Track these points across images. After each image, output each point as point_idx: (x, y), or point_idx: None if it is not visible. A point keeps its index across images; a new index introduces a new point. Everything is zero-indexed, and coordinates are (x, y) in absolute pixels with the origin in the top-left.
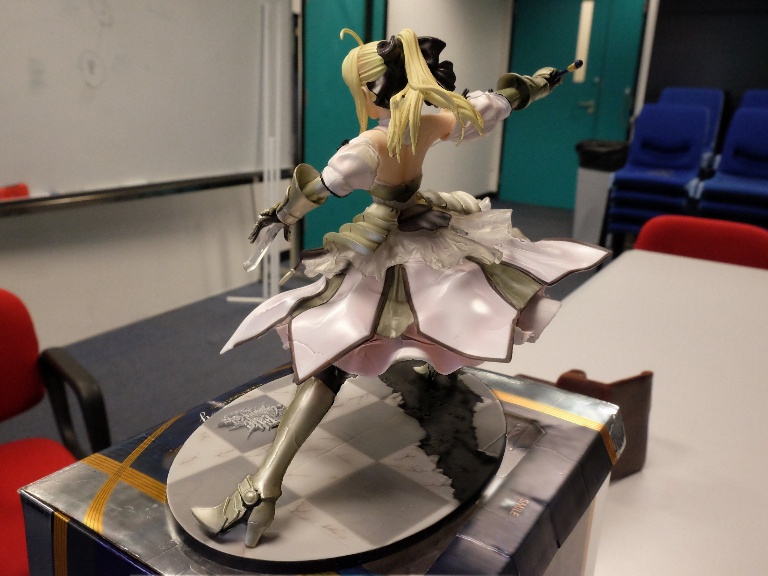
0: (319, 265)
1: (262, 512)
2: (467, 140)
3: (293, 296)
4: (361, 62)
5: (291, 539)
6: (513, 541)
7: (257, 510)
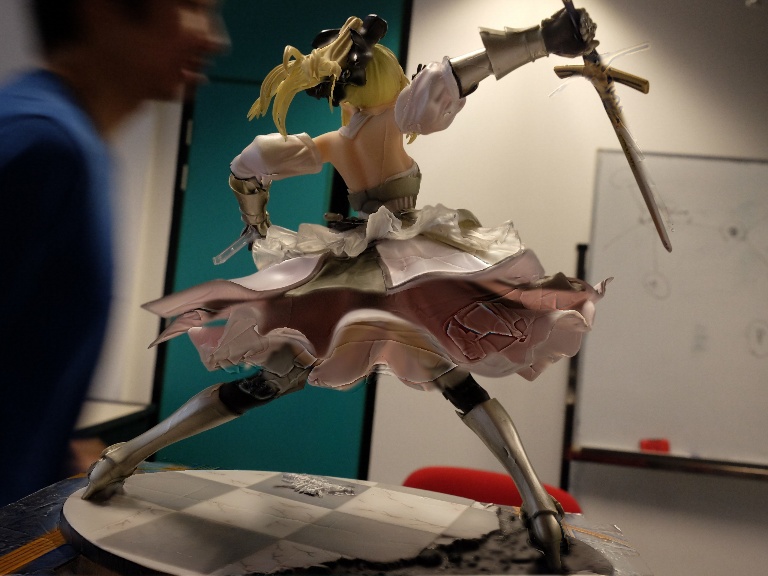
0: None
1: (100, 468)
2: (425, 127)
3: None
4: None
5: (102, 511)
6: None
7: (98, 463)
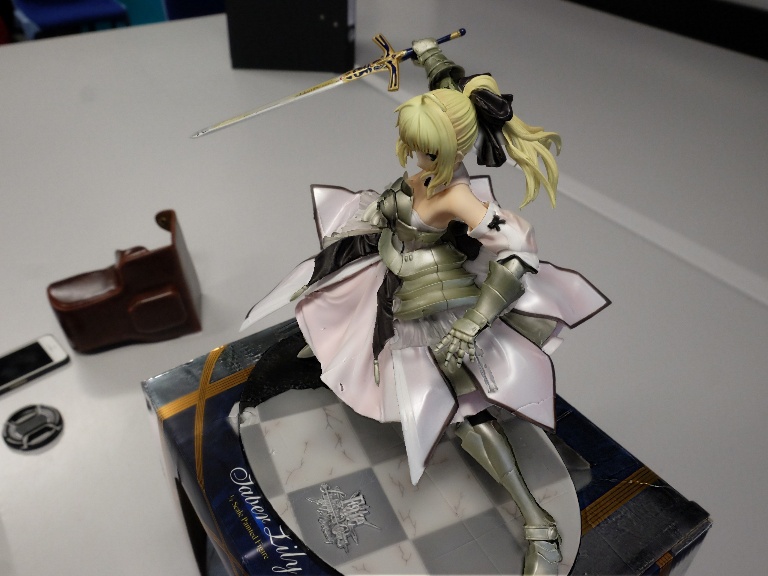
0: (441, 338)
1: None
2: None
3: (427, 381)
4: (458, 127)
5: None
6: (559, 400)
7: None
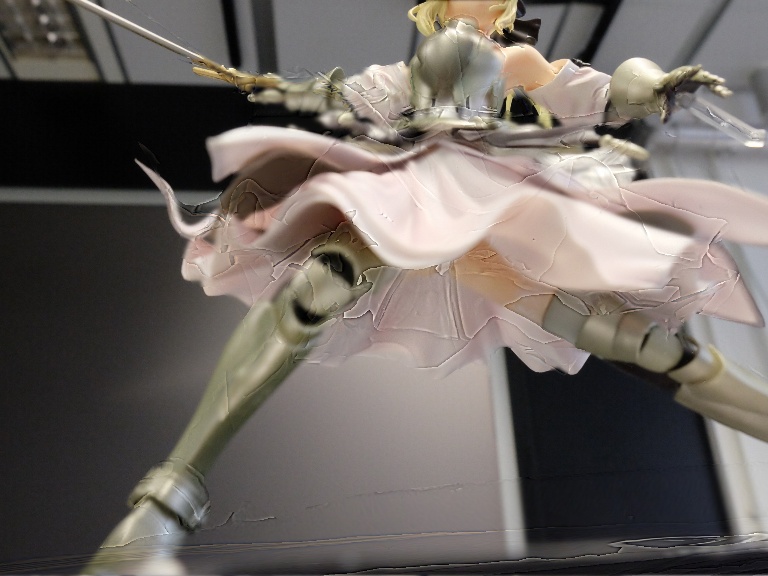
0: None
1: None
2: None
3: None
4: None
5: None
6: None
7: None
